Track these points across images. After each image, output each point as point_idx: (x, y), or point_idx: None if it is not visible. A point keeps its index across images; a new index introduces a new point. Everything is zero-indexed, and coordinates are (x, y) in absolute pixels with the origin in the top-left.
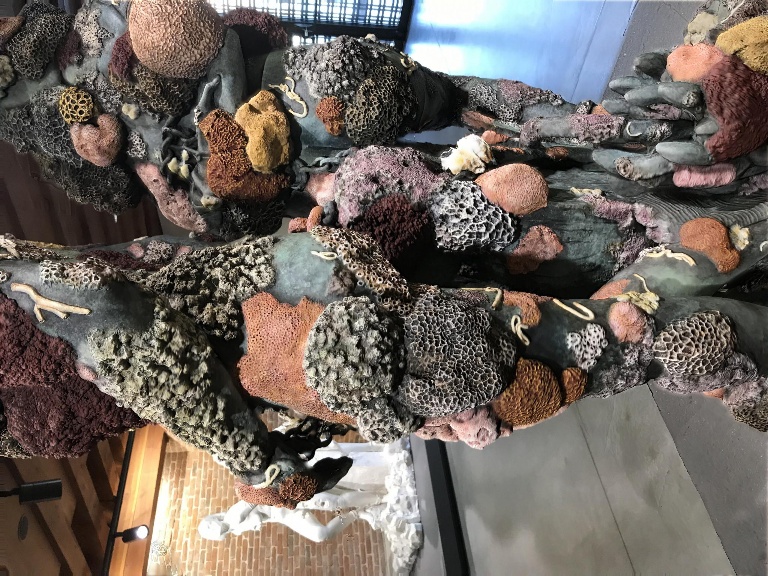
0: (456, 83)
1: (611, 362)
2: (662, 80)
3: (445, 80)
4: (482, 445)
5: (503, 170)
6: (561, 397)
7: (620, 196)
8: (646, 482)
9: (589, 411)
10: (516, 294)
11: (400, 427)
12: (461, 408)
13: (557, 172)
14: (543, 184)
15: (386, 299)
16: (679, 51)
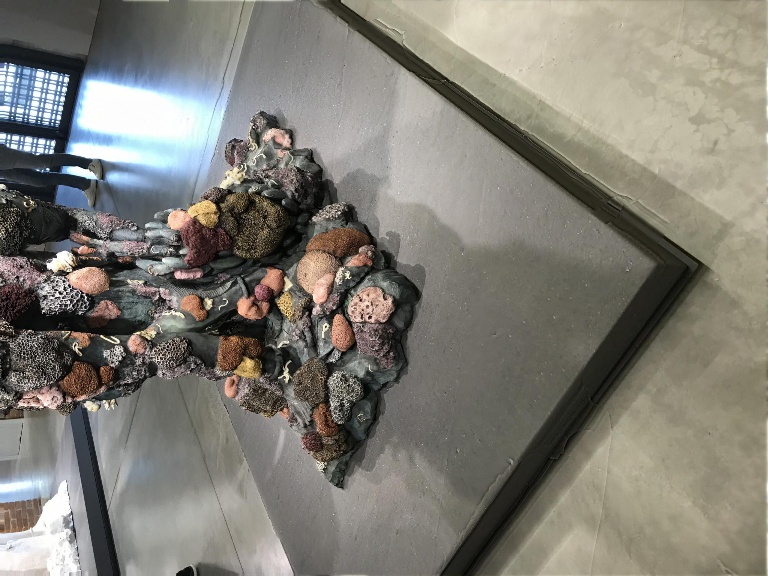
0: (70, 213)
1: (129, 364)
2: (167, 226)
3: (61, 211)
4: (55, 405)
5: (82, 270)
6: (98, 379)
7: (155, 284)
8: (238, 483)
9: (206, 444)
10: (78, 333)
11: (7, 397)
12: (39, 383)
13: (125, 271)
14: (106, 278)
15: (1, 336)
16: (173, 213)
